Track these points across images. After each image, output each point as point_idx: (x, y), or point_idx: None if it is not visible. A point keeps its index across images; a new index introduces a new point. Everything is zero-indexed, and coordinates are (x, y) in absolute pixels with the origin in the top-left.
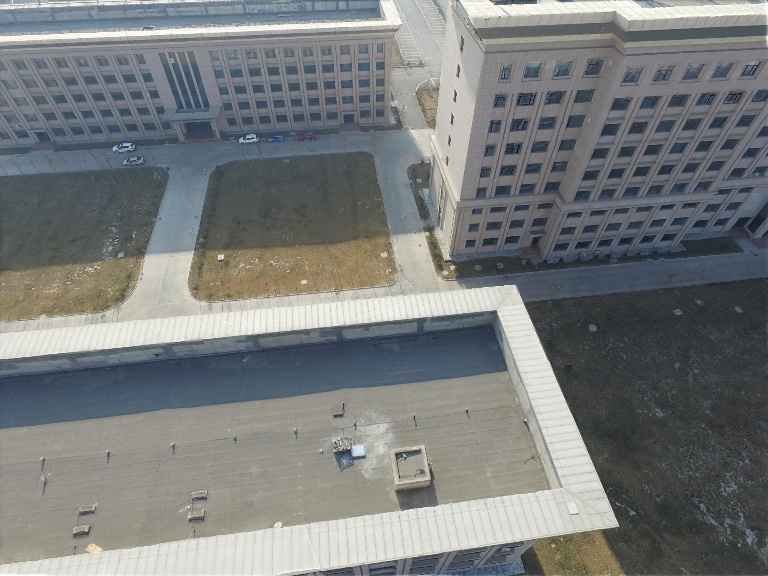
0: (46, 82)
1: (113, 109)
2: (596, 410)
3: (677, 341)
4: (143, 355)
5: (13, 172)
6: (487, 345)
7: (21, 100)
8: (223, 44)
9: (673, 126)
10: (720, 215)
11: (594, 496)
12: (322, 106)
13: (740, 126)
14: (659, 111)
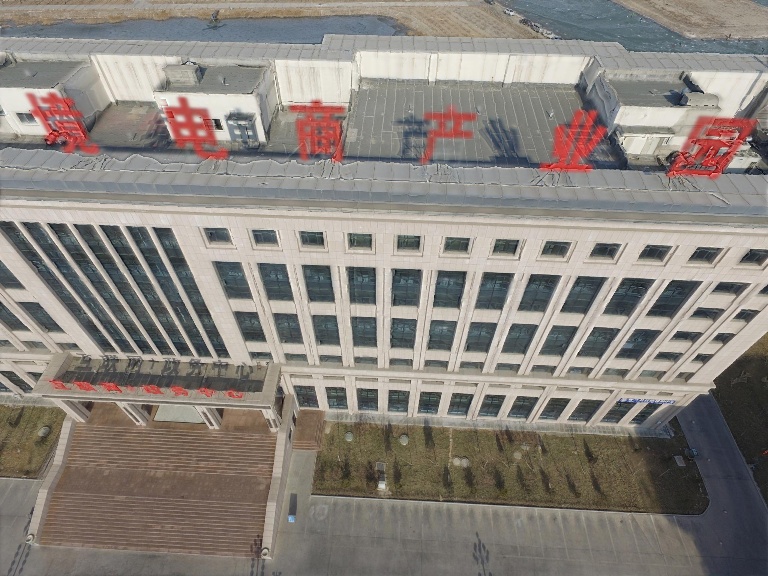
0: None
1: None
2: None
3: None
4: None
5: None
6: None
7: None
8: None
9: None
10: None
11: None
12: None
13: None
14: None
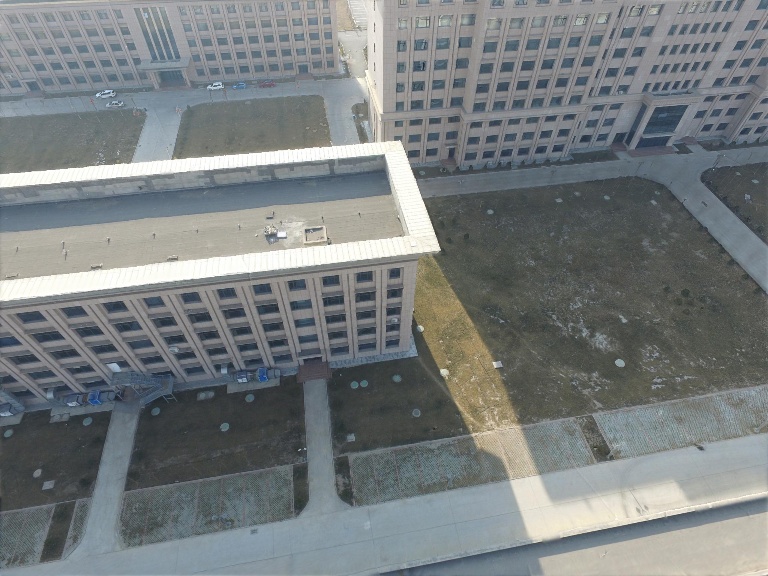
0: (36, 35)
1: (95, 60)
2: (485, 263)
3: (555, 219)
4: (130, 187)
5: (9, 114)
6: (380, 181)
7: (14, 52)
8: (190, 0)
9: (539, 45)
10: (600, 130)
11: (428, 238)
12: (279, 57)
13: (593, 45)
14: (525, 31)
